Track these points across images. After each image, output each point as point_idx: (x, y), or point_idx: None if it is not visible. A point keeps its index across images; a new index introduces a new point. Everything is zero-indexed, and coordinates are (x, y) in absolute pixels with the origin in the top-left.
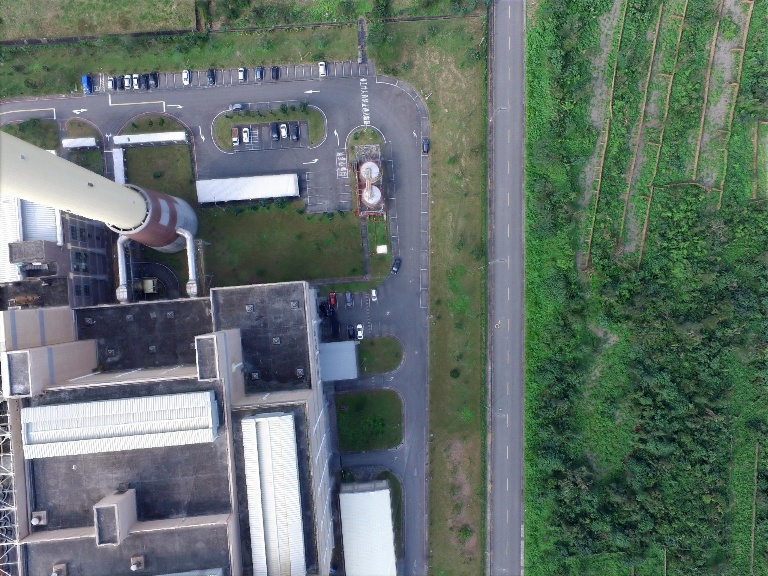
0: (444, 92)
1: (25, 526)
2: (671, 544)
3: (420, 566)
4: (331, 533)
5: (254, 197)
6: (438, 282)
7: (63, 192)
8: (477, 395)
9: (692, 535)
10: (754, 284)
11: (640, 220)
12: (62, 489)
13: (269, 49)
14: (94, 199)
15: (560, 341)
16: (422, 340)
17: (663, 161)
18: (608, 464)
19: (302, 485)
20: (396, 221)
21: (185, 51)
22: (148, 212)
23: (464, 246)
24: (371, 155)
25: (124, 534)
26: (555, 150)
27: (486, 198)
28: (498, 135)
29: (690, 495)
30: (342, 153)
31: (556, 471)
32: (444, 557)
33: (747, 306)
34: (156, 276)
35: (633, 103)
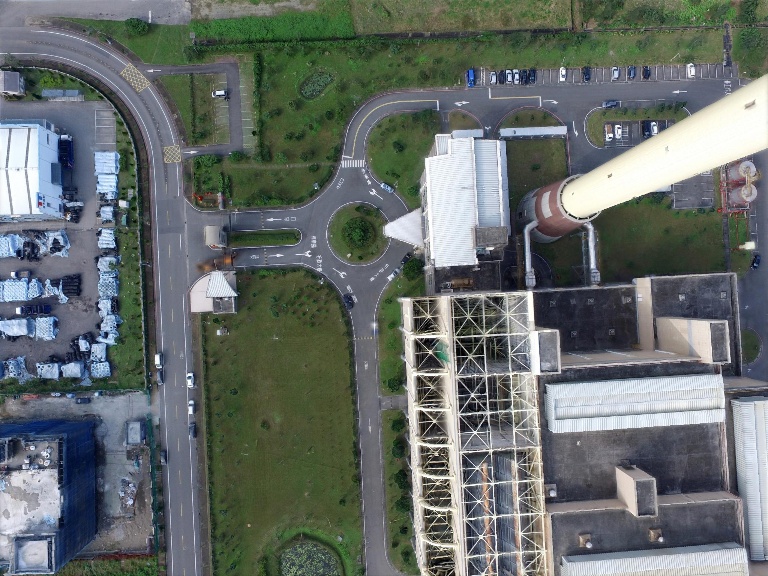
0: None
1: None
2: None
3: None
4: None
5: None
6: None
7: None
8: None
9: None
10: None
11: None
12: (567, 463)
13: None
14: None
15: None
16: None
17: None
18: None
19: None
20: (755, 219)
21: None
22: None
23: None
24: None
25: None
26: None
27: None
28: None
29: None
30: None
31: None
32: None
33: None
34: None
35: None
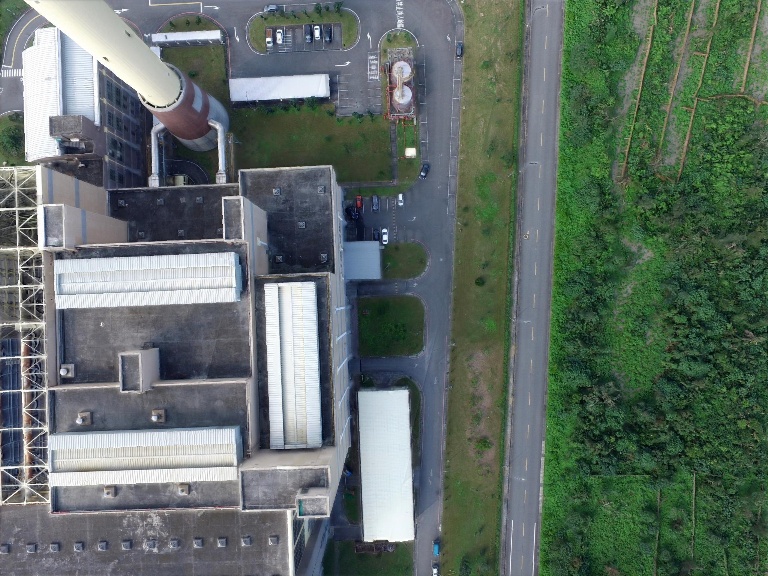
0: None
1: (54, 376)
2: (701, 469)
3: (436, 476)
4: (348, 431)
5: (285, 97)
6: (466, 189)
7: (101, 29)
8: (502, 306)
9: (724, 460)
10: None
11: (682, 133)
12: (90, 345)
13: None
14: (131, 51)
15: (591, 252)
16: (448, 247)
17: (709, 72)
18: (637, 384)
19: (321, 357)
20: (426, 126)
21: None
22: (182, 90)
23: (495, 153)
24: (403, 58)
25: (147, 385)
26: (594, 56)
27: (519, 105)
28: (535, 41)
29: (724, 419)
30: (374, 56)
31: (581, 387)
32: (461, 468)
33: None
34: (187, 174)
35: (679, 10)
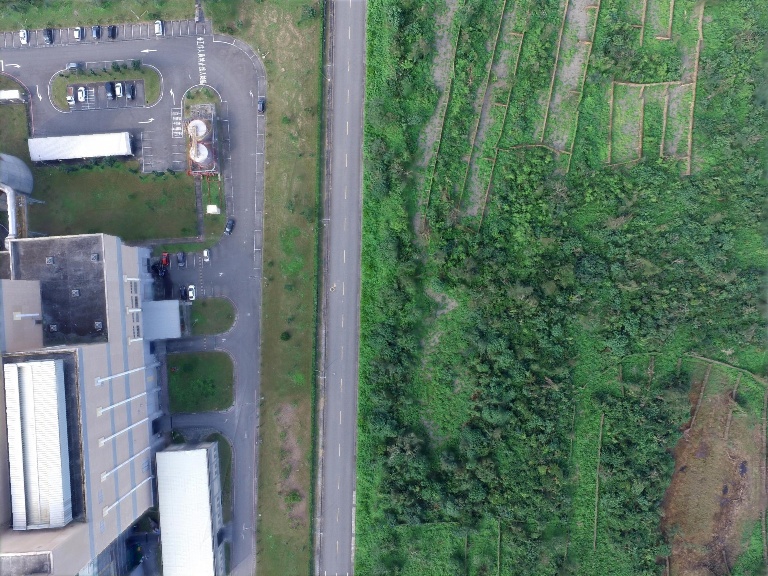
0: (281, 51)
1: None
2: (504, 515)
3: (249, 529)
4: (148, 491)
5: (86, 156)
6: (272, 243)
7: None
8: (310, 359)
9: (525, 506)
10: (605, 251)
11: (484, 183)
12: None
13: (106, 8)
14: None
15: (392, 304)
16: (255, 302)
17: (510, 122)
18: (445, 432)
19: (73, 433)
20: (231, 181)
21: (23, 10)
22: None
23: (298, 207)
24: (206, 115)
25: None
26: (393, 110)
27: (323, 159)
28: (337, 95)
29: (525, 465)
30: (178, 113)
31: (389, 437)
32: (272, 521)
33: (595, 273)
34: None
35: (478, 62)
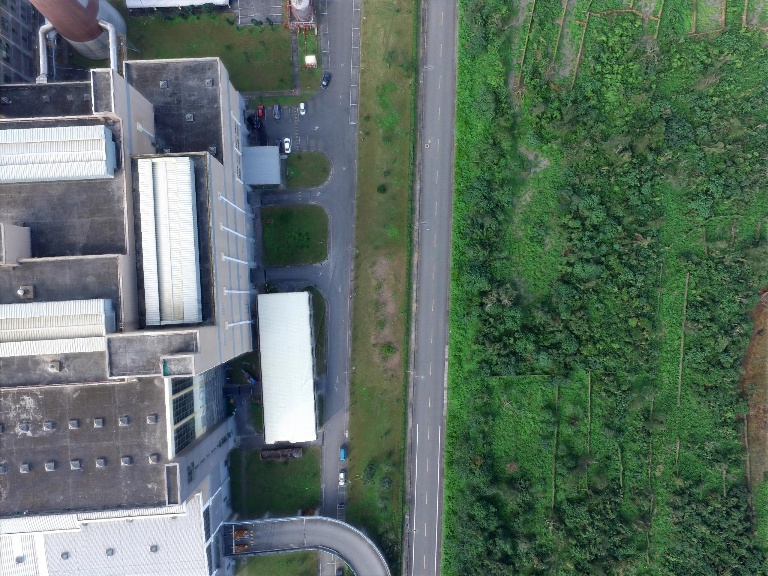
0: None
1: None
2: (595, 366)
3: (342, 382)
4: (249, 334)
5: (183, 4)
6: (368, 98)
7: None
8: (404, 213)
9: (616, 356)
10: (690, 116)
11: (575, 46)
12: None
13: None
14: None
15: (488, 158)
16: (350, 156)
17: None
18: (536, 289)
19: (201, 237)
20: (327, 36)
21: None
22: None
23: (395, 63)
24: None
25: (12, 259)
26: None
27: (419, 16)
28: None
29: (616, 318)
30: None
31: (482, 292)
32: (366, 373)
33: (681, 135)
34: None
35: None
